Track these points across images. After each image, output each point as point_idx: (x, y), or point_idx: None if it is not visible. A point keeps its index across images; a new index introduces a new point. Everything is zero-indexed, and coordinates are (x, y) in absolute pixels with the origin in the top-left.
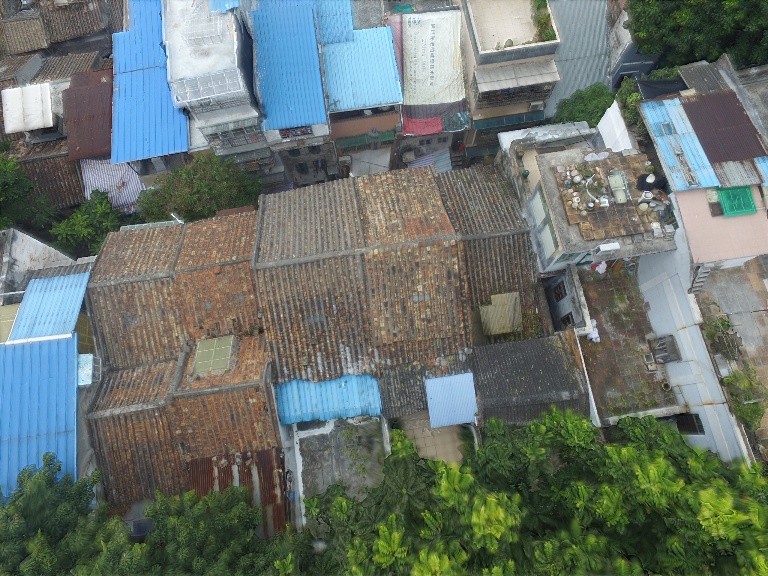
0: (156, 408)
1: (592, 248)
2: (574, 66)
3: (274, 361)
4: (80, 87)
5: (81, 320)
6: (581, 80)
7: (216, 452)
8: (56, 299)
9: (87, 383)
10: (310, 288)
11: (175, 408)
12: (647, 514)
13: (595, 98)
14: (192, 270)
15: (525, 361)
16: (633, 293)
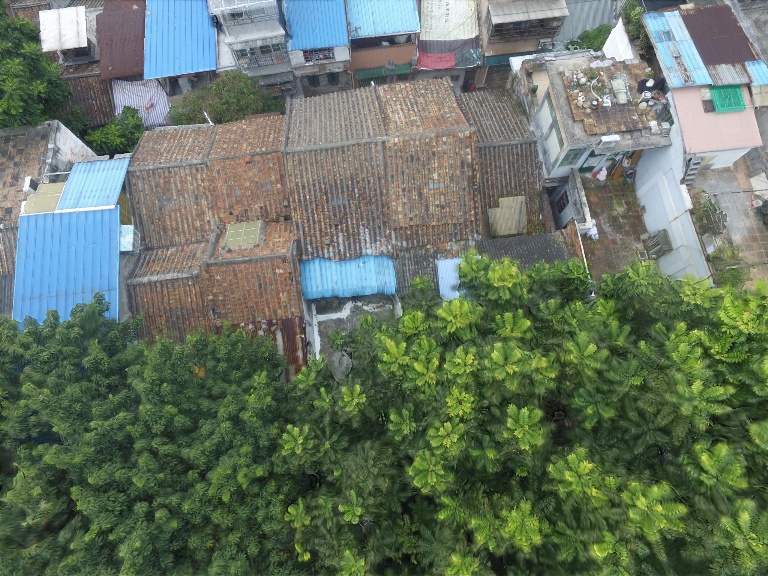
0: (190, 277)
1: (594, 142)
2: (582, 9)
3: (299, 239)
4: (113, 12)
5: (122, 198)
6: (588, 23)
7: (244, 319)
8: (99, 179)
9: (128, 250)
10: (335, 172)
11: (208, 275)
12: (635, 309)
13: (601, 37)
14: (225, 158)
15: (529, 252)
16: (630, 199)
